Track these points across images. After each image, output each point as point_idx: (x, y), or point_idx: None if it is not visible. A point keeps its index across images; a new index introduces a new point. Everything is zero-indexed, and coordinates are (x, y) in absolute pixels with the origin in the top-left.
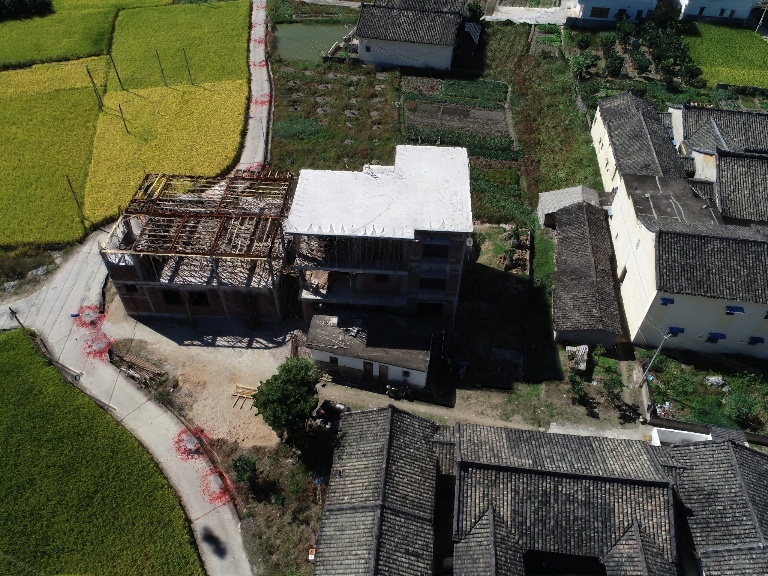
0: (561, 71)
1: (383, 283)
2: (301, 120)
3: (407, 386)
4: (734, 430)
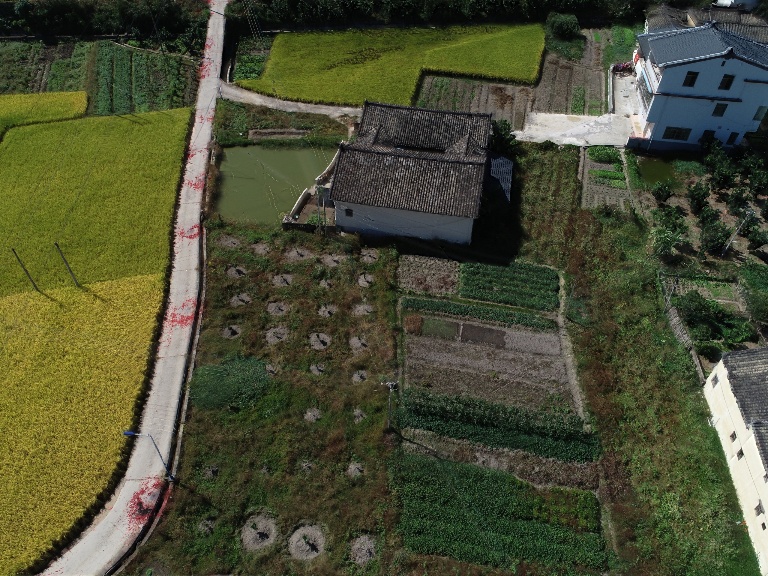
0: (634, 243)
1: None
2: (239, 363)
3: None
4: None
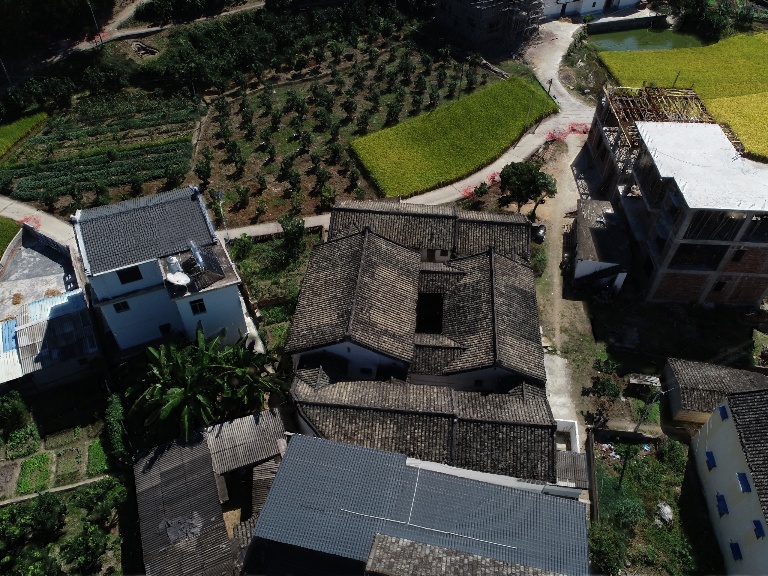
0: None
1: (648, 217)
2: None
3: (571, 266)
4: (587, 479)
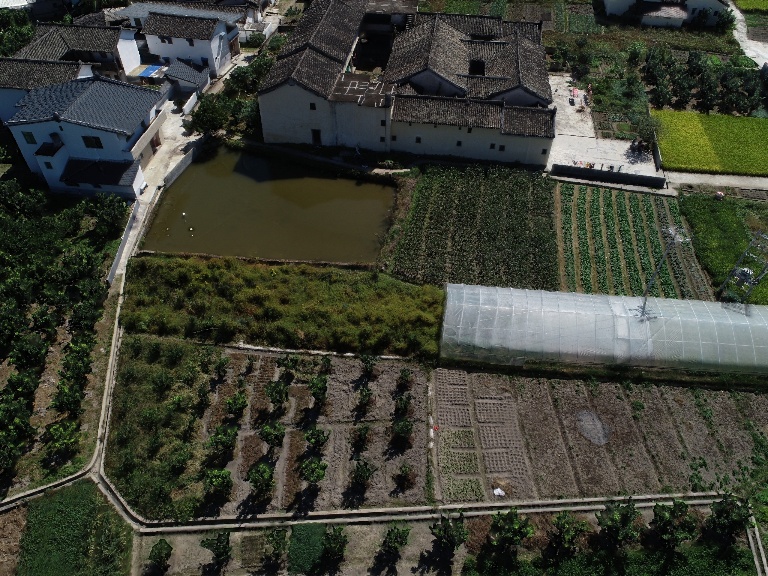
0: None
1: None
2: None
3: None
4: None
